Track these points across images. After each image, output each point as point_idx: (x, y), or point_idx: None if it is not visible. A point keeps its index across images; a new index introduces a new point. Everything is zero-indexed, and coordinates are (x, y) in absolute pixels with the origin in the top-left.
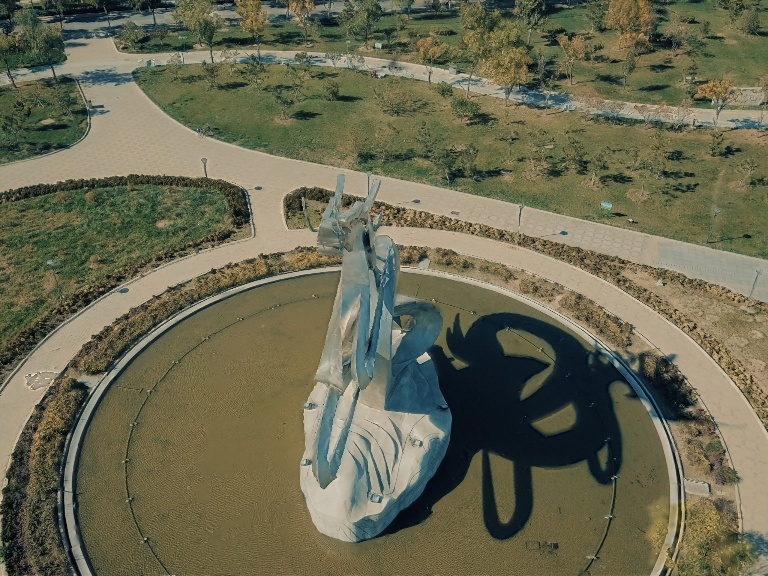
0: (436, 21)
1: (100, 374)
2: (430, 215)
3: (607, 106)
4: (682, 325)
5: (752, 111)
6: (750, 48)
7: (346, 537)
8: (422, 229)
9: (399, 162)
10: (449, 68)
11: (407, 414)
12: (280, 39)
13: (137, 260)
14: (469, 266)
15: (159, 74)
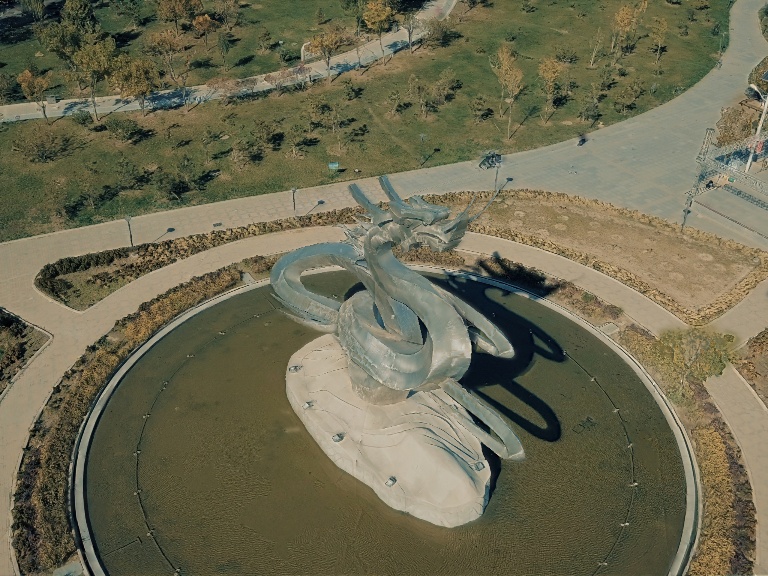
0: None
1: (72, 557)
2: (202, 236)
3: (243, 85)
4: (477, 230)
5: (334, 57)
6: (277, 8)
7: (477, 515)
8: (207, 251)
9: (110, 202)
10: (46, 99)
11: (420, 392)
12: None
13: None
14: None
15: None
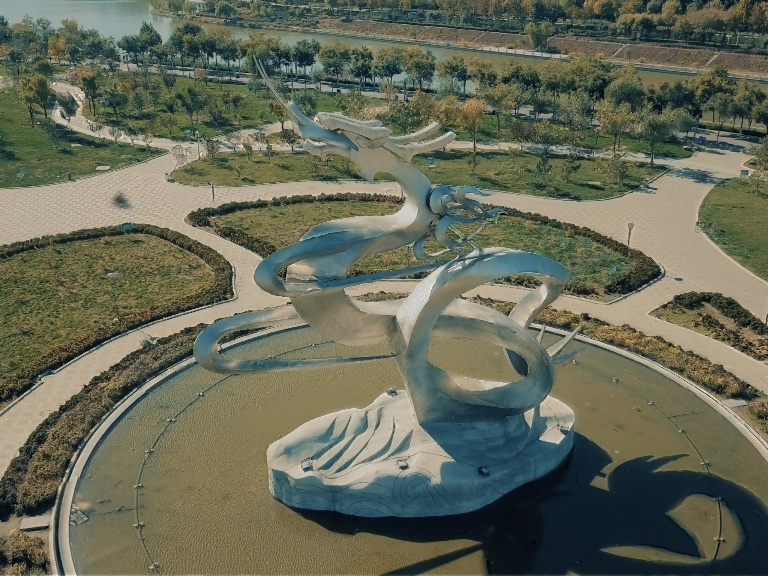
0: None
1: None
2: None
3: None
4: None
5: None
6: None
7: (270, 484)
8: None
9: None
10: None
11: (436, 443)
12: None
13: None
14: None
15: (747, 185)
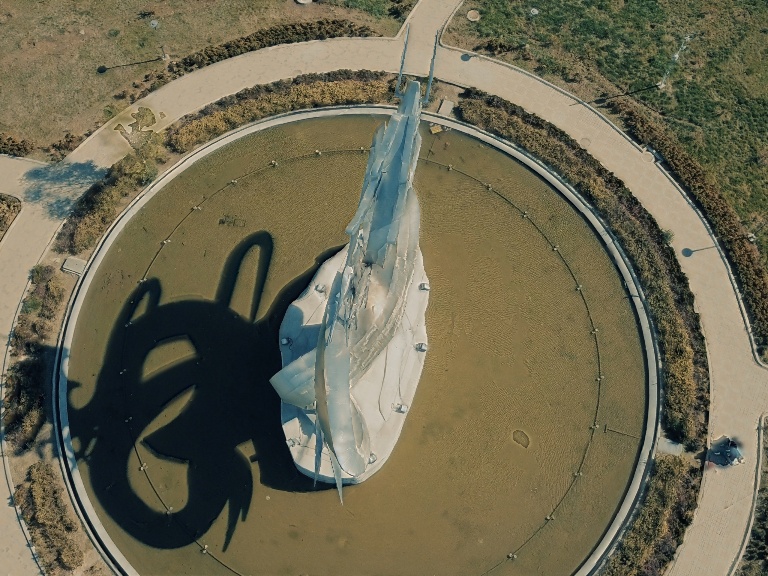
0: None
1: None
2: None
3: None
4: None
5: None
6: None
7: None
8: None
9: None
10: None
11: None
12: None
13: None
14: None
15: None
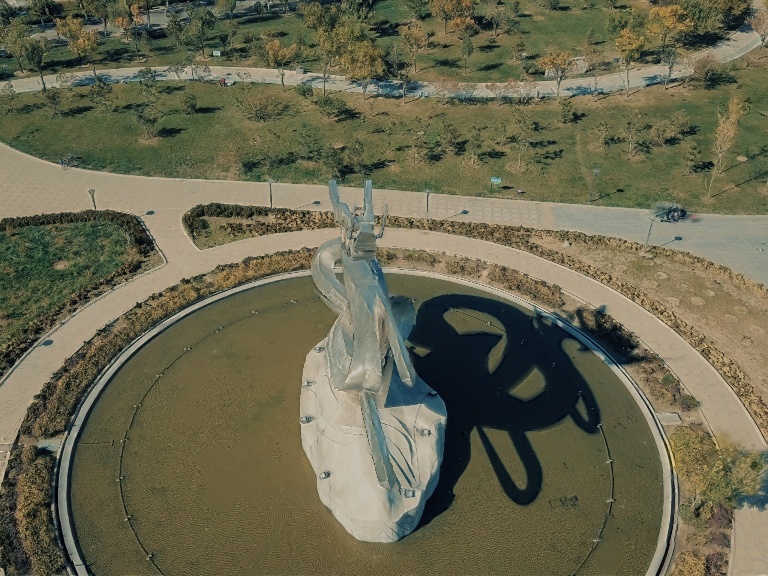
0: (261, 24)
1: (59, 435)
2: None
3: (462, 88)
4: (600, 278)
5: (581, 79)
6: (557, 22)
7: (388, 538)
8: (333, 229)
9: (284, 167)
10: (296, 69)
11: (405, 407)
12: (108, 57)
13: (49, 308)
14: (393, 257)
15: None
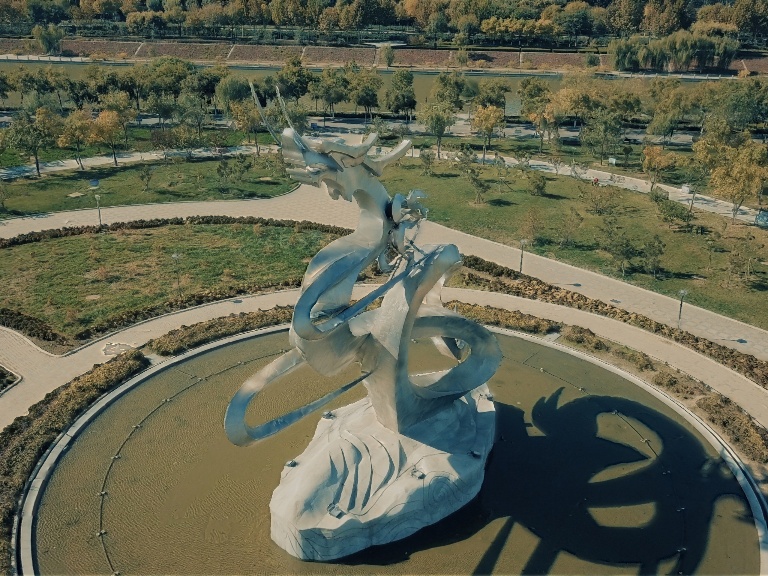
0: (693, 153)
1: (168, 356)
2: (583, 297)
3: None
4: None
5: None
6: None
7: (292, 549)
8: (568, 308)
9: (577, 251)
10: (682, 186)
11: (425, 445)
12: (516, 149)
13: (265, 281)
14: (602, 348)
15: None
